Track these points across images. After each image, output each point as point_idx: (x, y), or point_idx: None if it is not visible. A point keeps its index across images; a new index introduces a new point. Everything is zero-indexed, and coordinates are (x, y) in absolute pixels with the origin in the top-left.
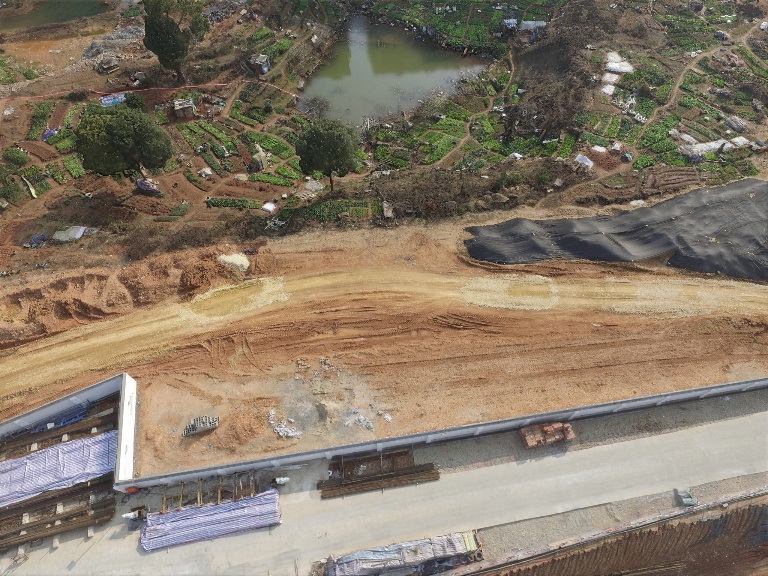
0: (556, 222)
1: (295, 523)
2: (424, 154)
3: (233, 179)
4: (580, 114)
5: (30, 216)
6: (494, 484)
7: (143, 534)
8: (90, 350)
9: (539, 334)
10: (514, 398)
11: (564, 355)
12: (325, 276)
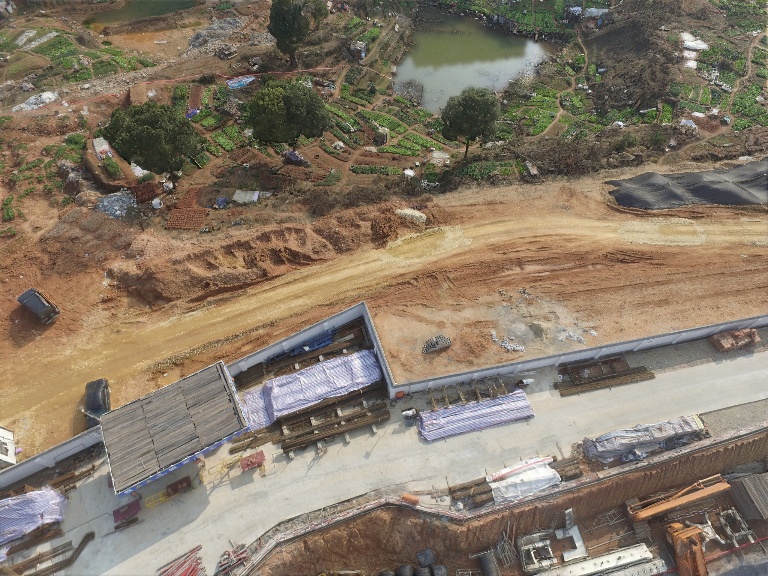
0: (682, 175)
1: (546, 415)
2: (528, 127)
3: (366, 151)
4: (673, 85)
5: (202, 184)
6: (702, 380)
7: (421, 428)
8: (313, 289)
9: (699, 264)
10: (695, 314)
11: (727, 279)
12: (496, 224)
